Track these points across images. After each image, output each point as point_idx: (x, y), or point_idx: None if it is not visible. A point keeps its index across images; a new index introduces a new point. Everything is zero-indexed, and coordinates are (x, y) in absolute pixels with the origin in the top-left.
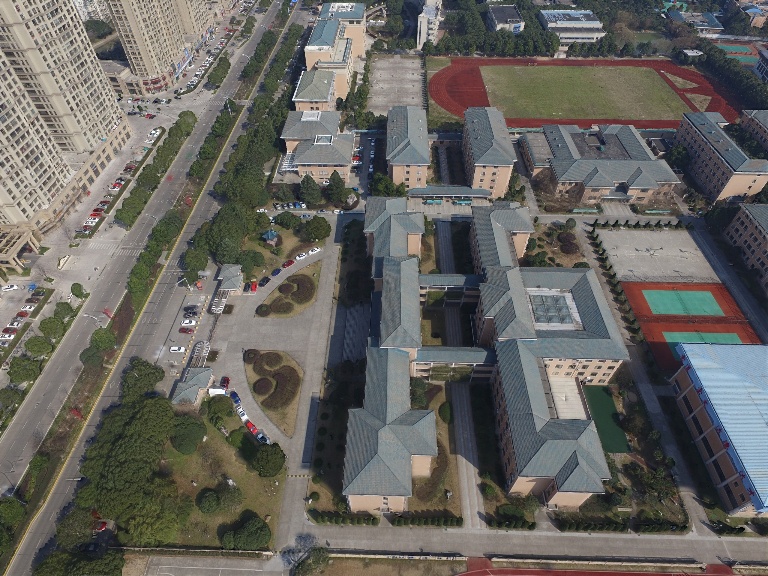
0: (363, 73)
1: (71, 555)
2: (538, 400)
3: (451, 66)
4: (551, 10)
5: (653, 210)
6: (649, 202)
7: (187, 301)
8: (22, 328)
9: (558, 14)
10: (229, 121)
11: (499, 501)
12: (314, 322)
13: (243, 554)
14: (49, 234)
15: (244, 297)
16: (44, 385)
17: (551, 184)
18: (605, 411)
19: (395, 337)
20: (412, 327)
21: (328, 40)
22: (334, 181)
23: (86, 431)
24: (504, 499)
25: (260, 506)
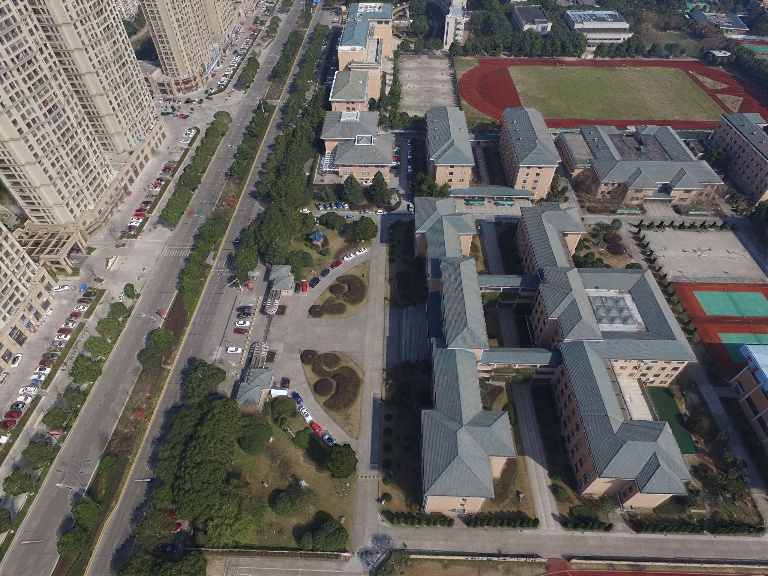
0: (392, 73)
1: (153, 556)
2: (611, 401)
3: (479, 66)
4: (576, 10)
5: (697, 211)
6: (691, 203)
7: (239, 302)
8: (77, 328)
9: (584, 14)
10: (264, 121)
11: (572, 502)
12: (368, 323)
13: (322, 555)
14: (94, 234)
15: (296, 298)
16: (104, 386)
17: (593, 185)
18: (669, 412)
19: (462, 338)
20: (478, 328)
21: (360, 40)
22: (378, 182)
23: (151, 432)
24: (576, 500)
25: (333, 507)
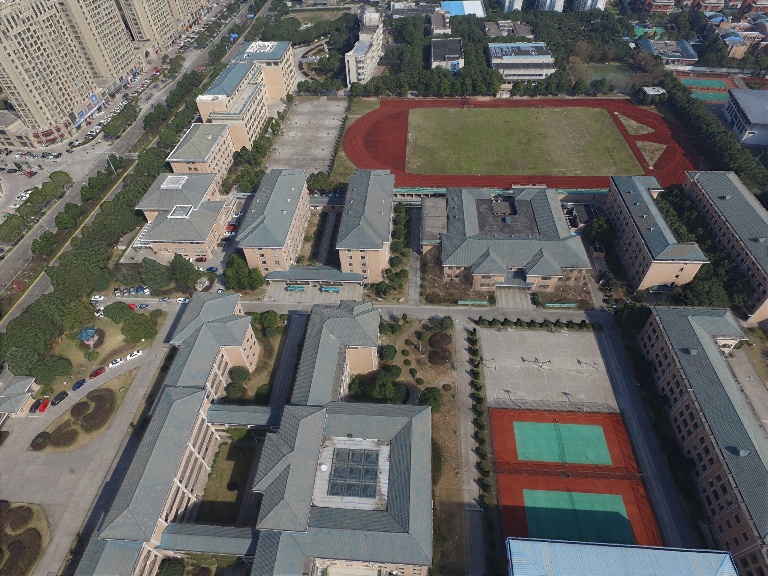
0: None
1: None
2: None
3: (378, 109)
4: (501, 43)
5: (555, 303)
6: (556, 290)
7: None
8: None
9: (507, 47)
10: (107, 181)
11: None
12: (94, 460)
13: None
14: None
15: (27, 420)
16: None
17: (437, 267)
18: None
19: (118, 525)
20: (147, 508)
21: (228, 87)
22: (176, 265)
23: None
24: None
25: None
